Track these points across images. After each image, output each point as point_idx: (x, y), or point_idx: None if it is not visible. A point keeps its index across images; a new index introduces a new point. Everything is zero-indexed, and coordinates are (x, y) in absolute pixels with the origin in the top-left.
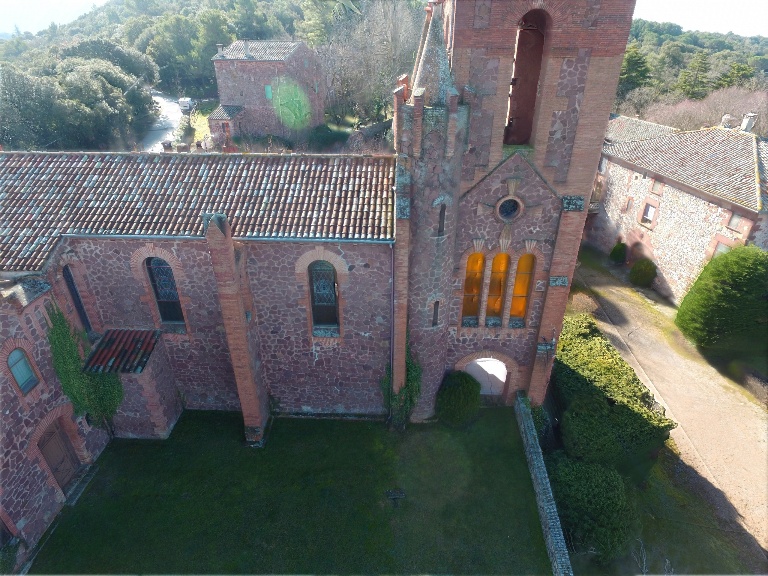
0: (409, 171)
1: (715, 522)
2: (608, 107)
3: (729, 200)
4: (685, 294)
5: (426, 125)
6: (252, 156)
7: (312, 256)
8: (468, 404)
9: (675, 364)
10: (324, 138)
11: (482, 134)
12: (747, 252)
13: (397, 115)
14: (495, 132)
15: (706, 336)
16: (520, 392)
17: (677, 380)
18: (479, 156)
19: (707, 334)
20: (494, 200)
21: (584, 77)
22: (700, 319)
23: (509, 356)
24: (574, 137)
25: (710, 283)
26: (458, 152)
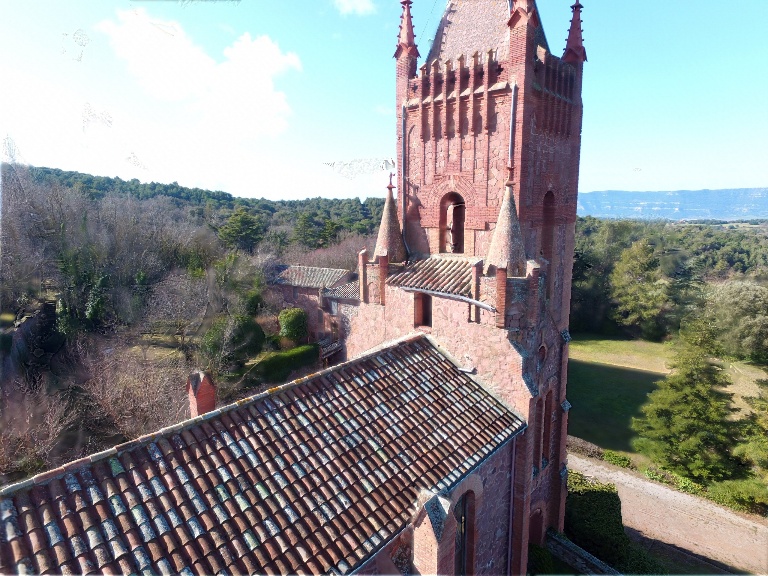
0: (520, 344)
1: (643, 547)
2: None
3: None
4: None
5: None
6: (283, 390)
7: (458, 493)
8: (552, 574)
9: None
10: None
11: None
12: None
13: (505, 290)
14: None
15: None
16: (549, 531)
17: None
18: None
19: None
20: None
21: (564, 238)
22: None
23: (542, 499)
24: (562, 284)
25: None
26: None
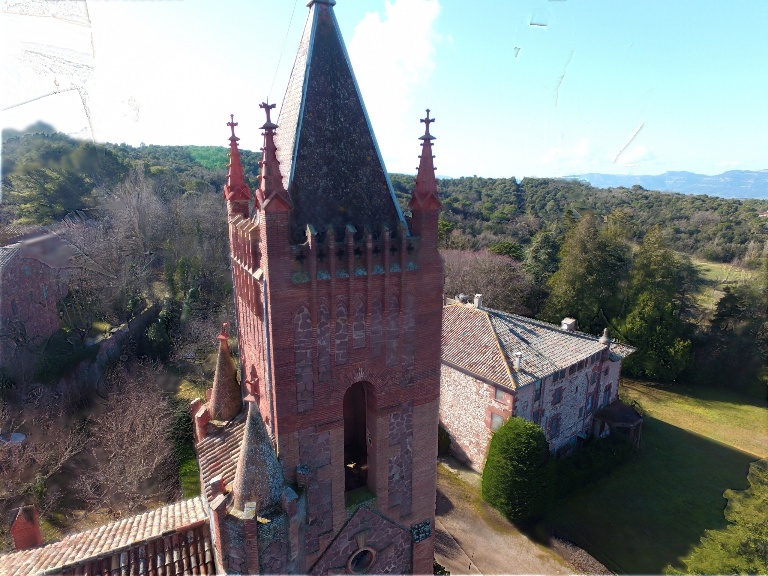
0: None
1: None
2: (435, 441)
3: (491, 379)
4: (479, 458)
5: (262, 541)
6: None
7: None
8: None
9: (497, 546)
10: (64, 361)
11: (321, 503)
12: (518, 427)
13: (220, 531)
14: (335, 497)
15: (512, 510)
16: None
17: (506, 567)
18: (321, 525)
19: (512, 507)
20: (344, 559)
21: (410, 423)
22: (503, 495)
23: None
24: (411, 474)
25: (501, 460)
26: (301, 542)
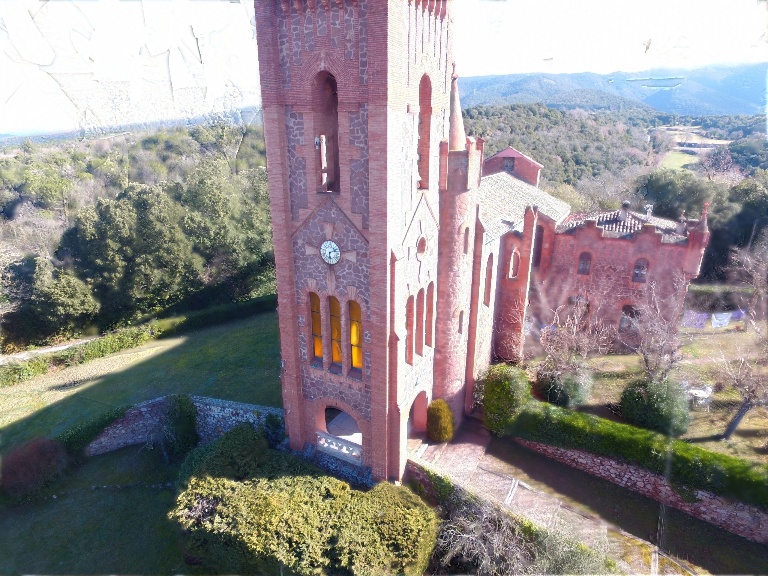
0: None
1: None
2: None
3: None
4: None
5: None
6: None
7: None
8: None
9: None
10: None
11: None
12: None
13: None
14: None
15: None
16: None
17: None
18: None
19: None
20: None
21: None
22: None
23: None
24: None
25: None
26: None
